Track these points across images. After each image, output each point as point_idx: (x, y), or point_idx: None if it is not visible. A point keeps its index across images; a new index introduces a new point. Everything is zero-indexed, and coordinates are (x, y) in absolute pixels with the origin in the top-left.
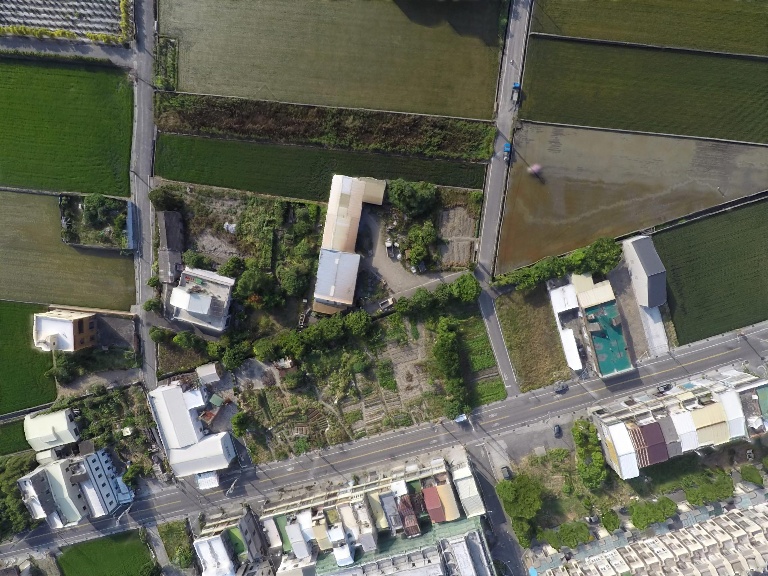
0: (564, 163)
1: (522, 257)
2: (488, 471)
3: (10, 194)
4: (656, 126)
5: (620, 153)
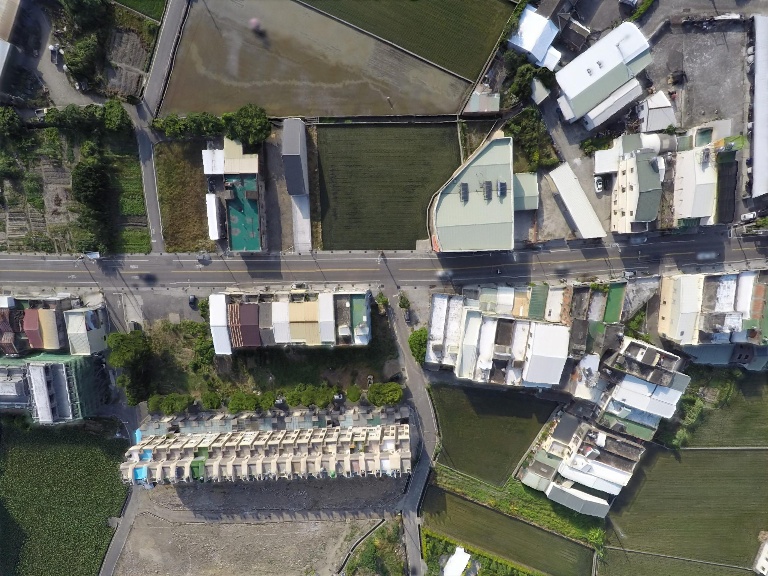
0: (245, 21)
1: (188, 108)
2: (121, 324)
3: None
4: (338, 10)
5: (301, 28)
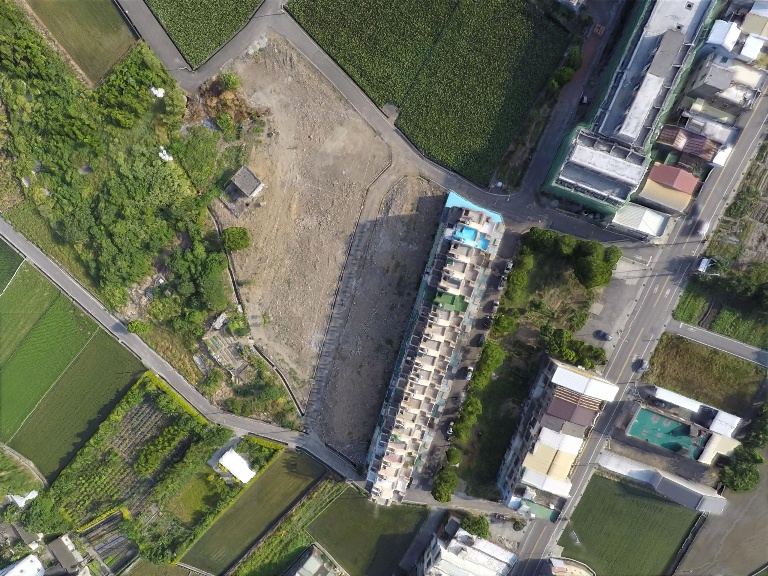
0: None
1: None
2: None
3: None
4: None
5: None
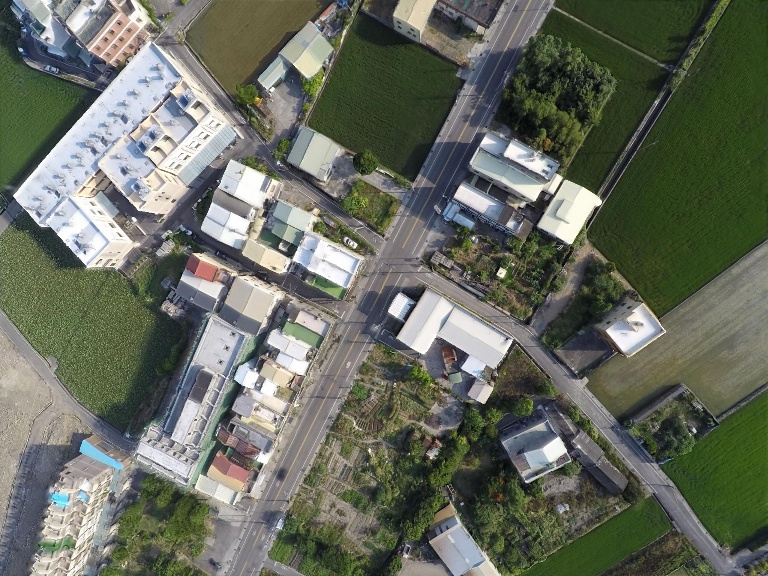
0: None
1: None
2: None
3: (764, 382)
4: None
5: None
